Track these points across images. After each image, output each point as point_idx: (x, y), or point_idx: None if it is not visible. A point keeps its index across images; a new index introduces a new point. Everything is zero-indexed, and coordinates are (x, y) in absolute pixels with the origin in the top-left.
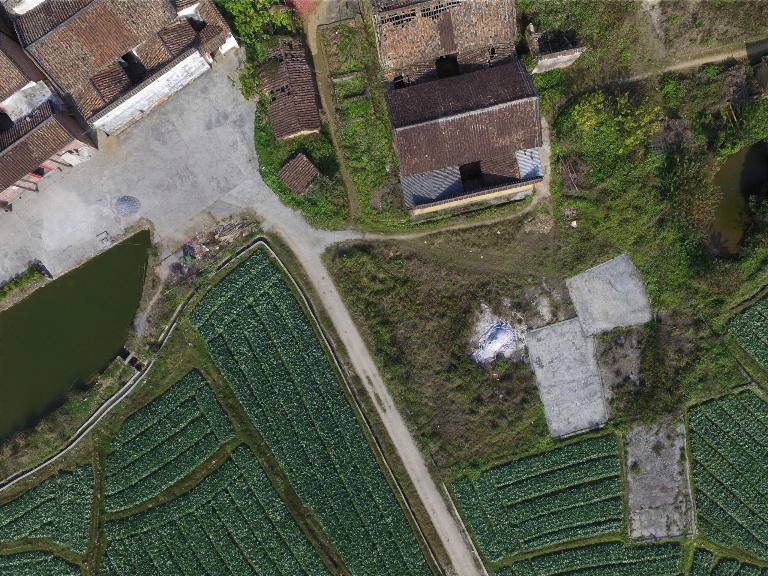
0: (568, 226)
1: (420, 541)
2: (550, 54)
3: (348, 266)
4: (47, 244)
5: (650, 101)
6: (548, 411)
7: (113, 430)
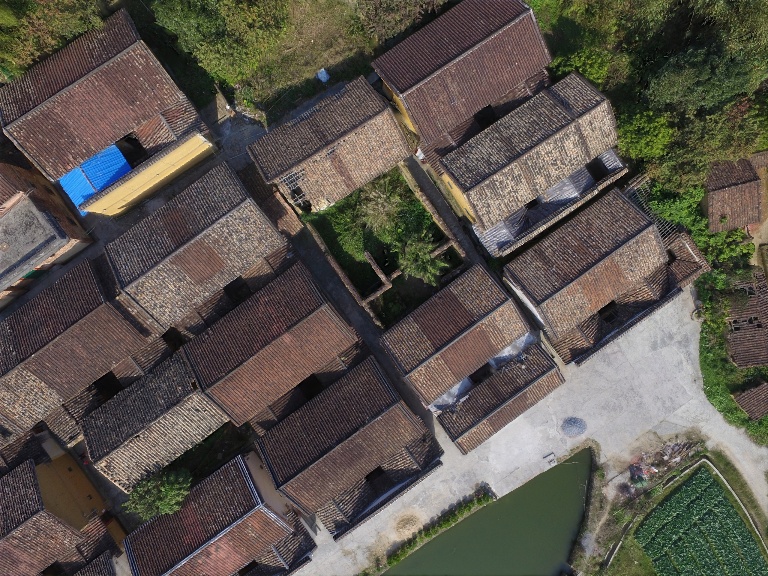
0: None
1: None
2: None
3: None
4: (494, 466)
5: None
6: None
7: None
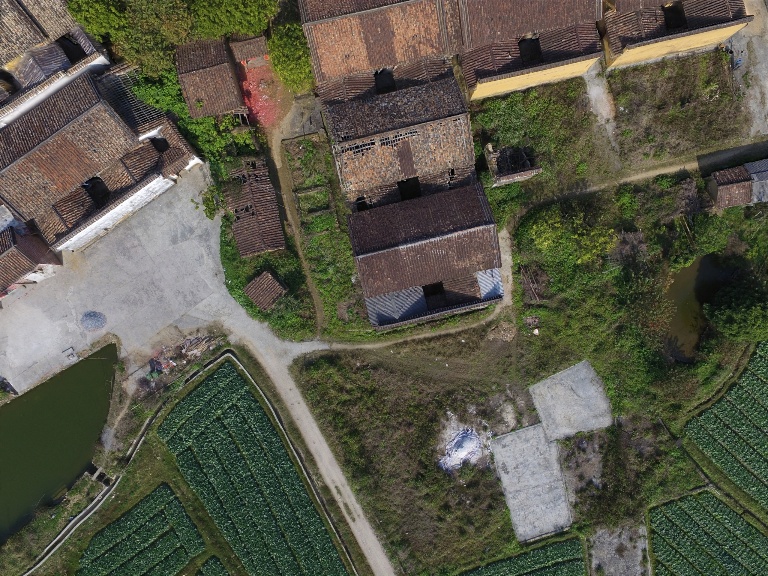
0: (530, 334)
1: None
2: (508, 176)
3: (315, 378)
4: (12, 361)
5: (606, 214)
6: (514, 516)
7: (81, 546)
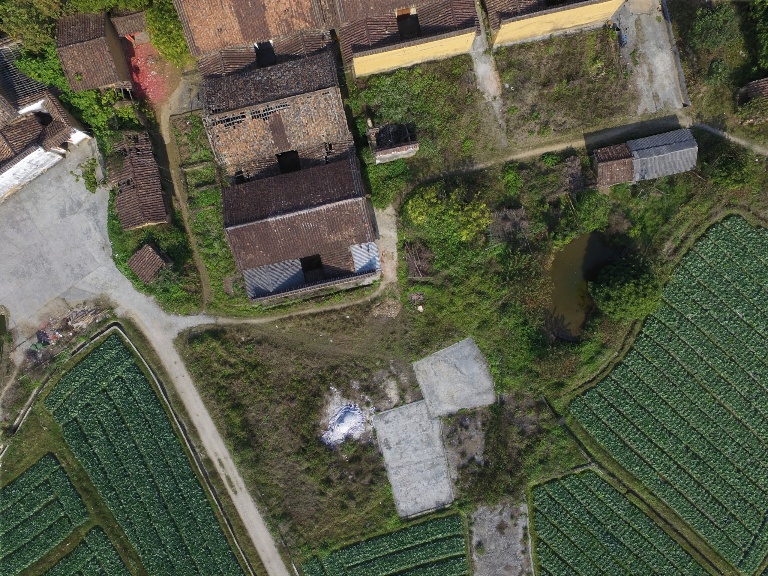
0: (415, 311)
1: None
2: (384, 151)
3: (199, 351)
4: None
5: (489, 191)
6: (396, 491)
7: None
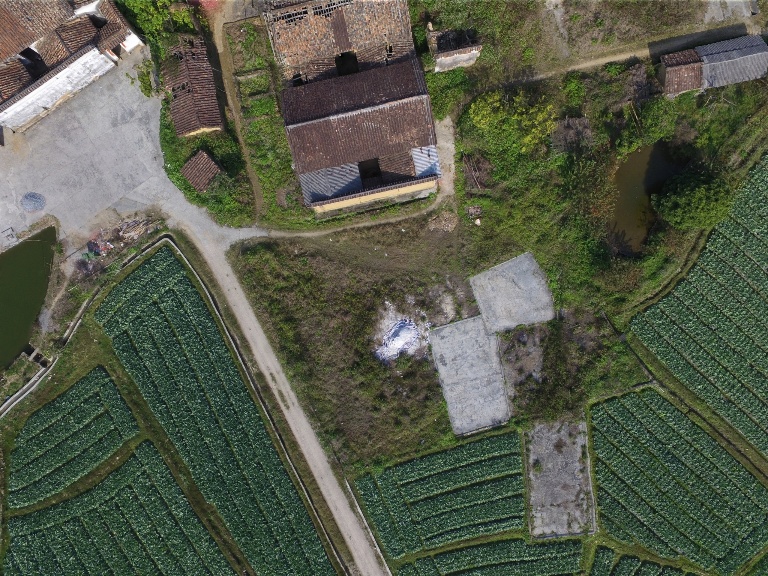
0: (472, 224)
1: (322, 538)
2: (446, 52)
3: (252, 263)
4: None
5: (551, 100)
6: (451, 408)
7: (18, 426)
